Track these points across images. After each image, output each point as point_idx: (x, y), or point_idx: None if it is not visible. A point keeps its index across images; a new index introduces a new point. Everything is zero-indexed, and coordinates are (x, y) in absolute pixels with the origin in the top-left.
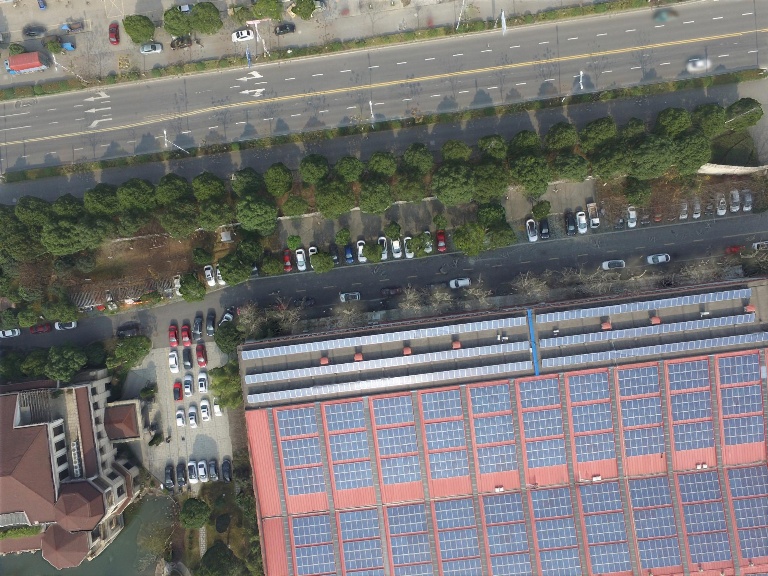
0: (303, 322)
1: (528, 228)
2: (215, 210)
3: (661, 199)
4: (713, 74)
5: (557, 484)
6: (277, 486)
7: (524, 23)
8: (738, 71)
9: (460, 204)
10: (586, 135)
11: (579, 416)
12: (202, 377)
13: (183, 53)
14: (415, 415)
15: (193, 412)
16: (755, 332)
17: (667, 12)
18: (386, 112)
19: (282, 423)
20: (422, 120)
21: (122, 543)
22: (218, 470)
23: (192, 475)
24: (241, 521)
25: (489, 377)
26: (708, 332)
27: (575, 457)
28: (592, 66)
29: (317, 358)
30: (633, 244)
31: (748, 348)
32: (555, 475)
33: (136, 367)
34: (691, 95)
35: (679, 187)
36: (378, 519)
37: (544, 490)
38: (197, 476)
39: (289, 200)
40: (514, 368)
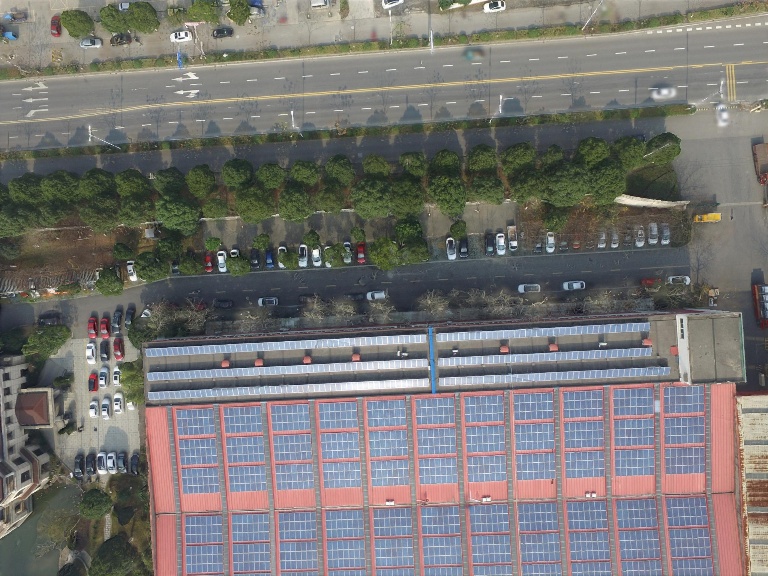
0: (218, 323)
1: (447, 246)
2: (134, 207)
3: (578, 227)
4: (641, 106)
5: (447, 502)
6: (173, 483)
7: (458, 43)
8: (666, 105)
9: (378, 218)
10: (505, 158)
11: (473, 436)
12: (117, 370)
13: (122, 50)
14: (312, 424)
15: (106, 404)
16: (651, 366)
17: (600, 41)
18: (316, 121)
19: (181, 422)
20: (350, 132)
21: (32, 527)
22: (127, 463)
23: (101, 466)
24: (146, 515)
25: (387, 391)
26: (605, 363)
27: (466, 477)
28: (522, 90)
29: (220, 360)
30: (550, 269)
31: (643, 381)
32: (446, 493)
33: (54, 355)
34: (618, 125)
35: (595, 216)
36: (269, 523)
37: (434, 507)
38: (106, 467)
39: (207, 202)
40: (411, 384)
